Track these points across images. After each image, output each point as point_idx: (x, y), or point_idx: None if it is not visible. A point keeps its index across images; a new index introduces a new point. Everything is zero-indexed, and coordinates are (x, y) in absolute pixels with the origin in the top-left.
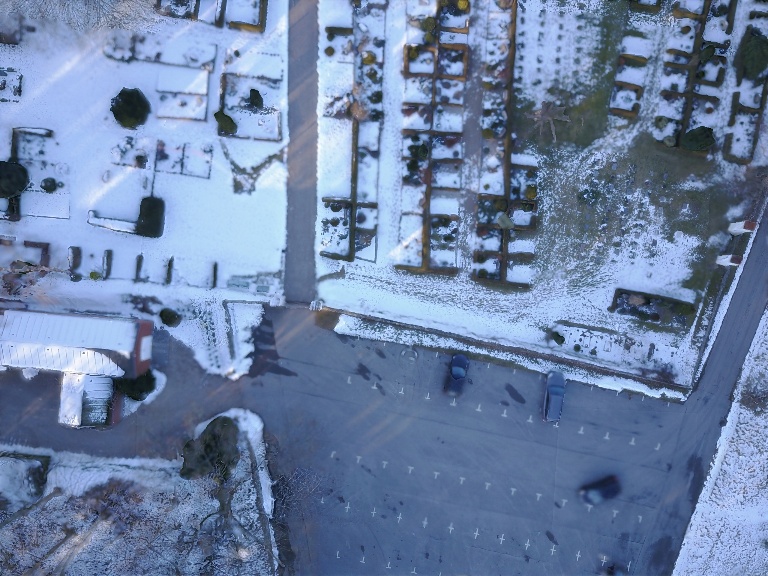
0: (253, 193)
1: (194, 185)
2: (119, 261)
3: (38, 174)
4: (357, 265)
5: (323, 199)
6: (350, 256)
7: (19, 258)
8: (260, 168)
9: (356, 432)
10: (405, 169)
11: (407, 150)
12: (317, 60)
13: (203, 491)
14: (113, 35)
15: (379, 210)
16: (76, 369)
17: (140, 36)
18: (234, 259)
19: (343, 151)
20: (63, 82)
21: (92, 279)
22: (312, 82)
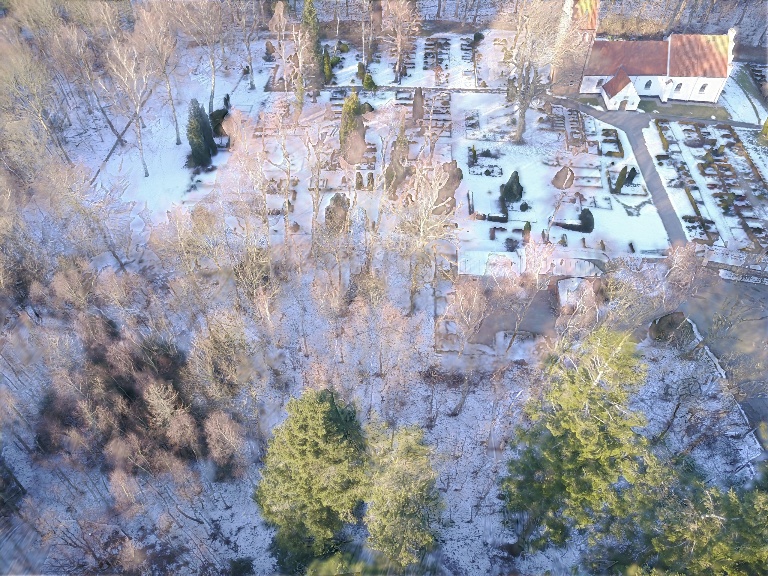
0: (639, 216)
1: (604, 212)
2: (570, 241)
3: (515, 204)
4: (716, 248)
5: (683, 216)
6: (712, 240)
7: (510, 237)
8: (639, 206)
9: (763, 332)
10: (722, 209)
11: (719, 202)
12: (655, 167)
13: (673, 355)
14: (546, 157)
15: (716, 226)
16: (571, 273)
17: (560, 157)
18: (639, 243)
19: (684, 200)
20: (523, 172)
21: (560, 244)
22: (656, 174)
